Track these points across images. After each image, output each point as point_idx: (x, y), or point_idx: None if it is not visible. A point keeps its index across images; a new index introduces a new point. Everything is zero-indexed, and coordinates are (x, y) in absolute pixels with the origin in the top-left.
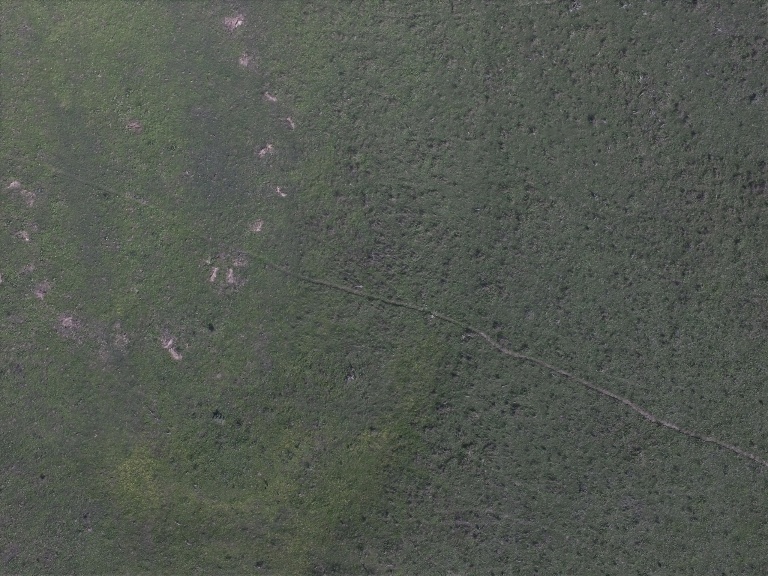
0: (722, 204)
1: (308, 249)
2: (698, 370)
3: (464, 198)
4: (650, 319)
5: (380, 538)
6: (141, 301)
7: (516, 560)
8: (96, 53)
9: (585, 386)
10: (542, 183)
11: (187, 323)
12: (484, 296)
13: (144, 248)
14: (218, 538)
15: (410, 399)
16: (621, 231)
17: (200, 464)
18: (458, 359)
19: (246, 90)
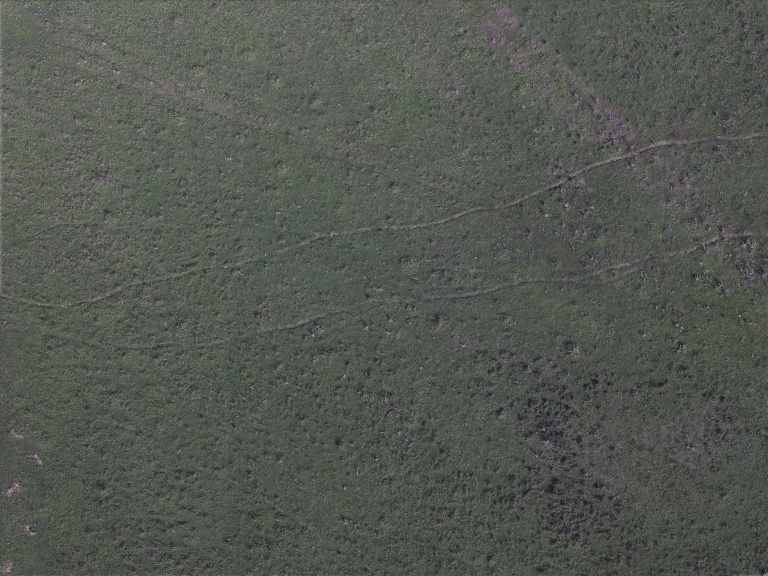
0: (473, 521)
1: None
2: None
3: (214, 528)
4: None
5: None
6: None
7: None
8: None
9: None
10: (292, 510)
11: None
12: None
13: None
14: None
15: None
16: (373, 553)
17: None
18: None
19: None
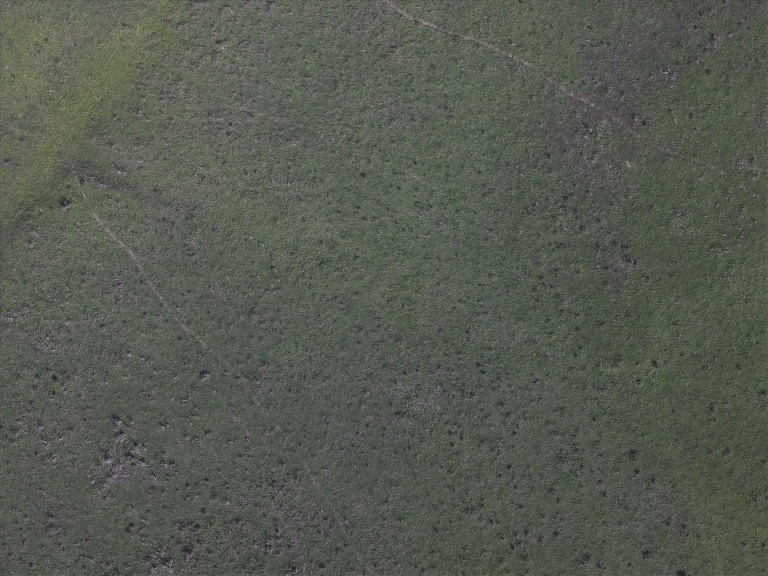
0: None
1: None
2: None
3: None
4: None
5: (131, 134)
6: None
7: (269, 157)
8: None
9: None
10: None
11: None
12: None
13: None
14: None
15: None
16: None
17: None
18: None
19: None
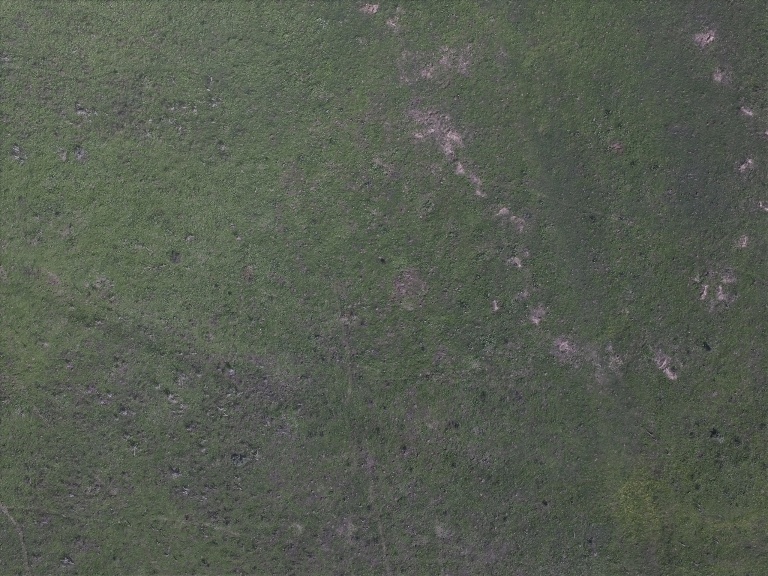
0: None
1: None
2: None
3: None
4: None
5: None
6: (633, 322)
7: None
8: (572, 76)
9: None
10: None
11: (680, 342)
12: None
13: (632, 269)
14: (723, 558)
15: None
16: None
17: (701, 484)
18: None
19: (721, 106)
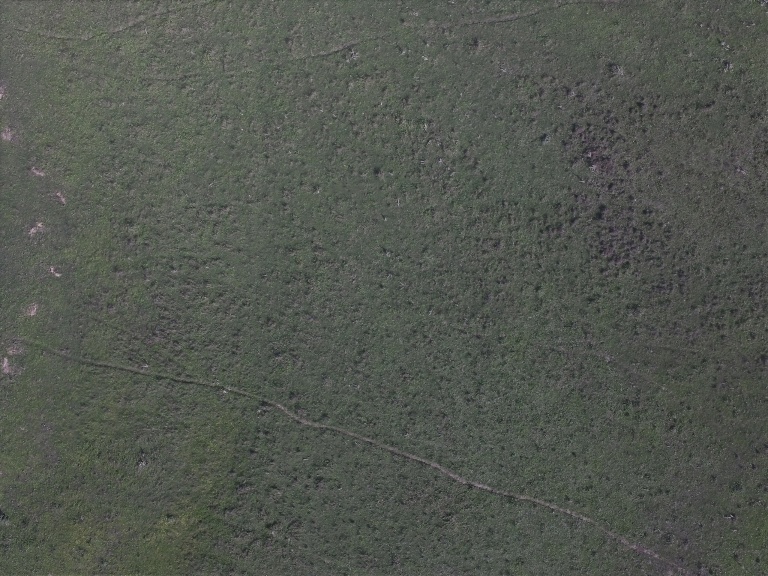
0: (520, 251)
1: (89, 330)
2: (506, 426)
3: (250, 264)
4: (453, 376)
5: None
6: None
7: None
8: None
9: (390, 452)
10: (331, 243)
11: None
12: (278, 366)
13: None
14: None
15: (207, 481)
16: (417, 287)
17: None
18: (255, 434)
19: (11, 167)
